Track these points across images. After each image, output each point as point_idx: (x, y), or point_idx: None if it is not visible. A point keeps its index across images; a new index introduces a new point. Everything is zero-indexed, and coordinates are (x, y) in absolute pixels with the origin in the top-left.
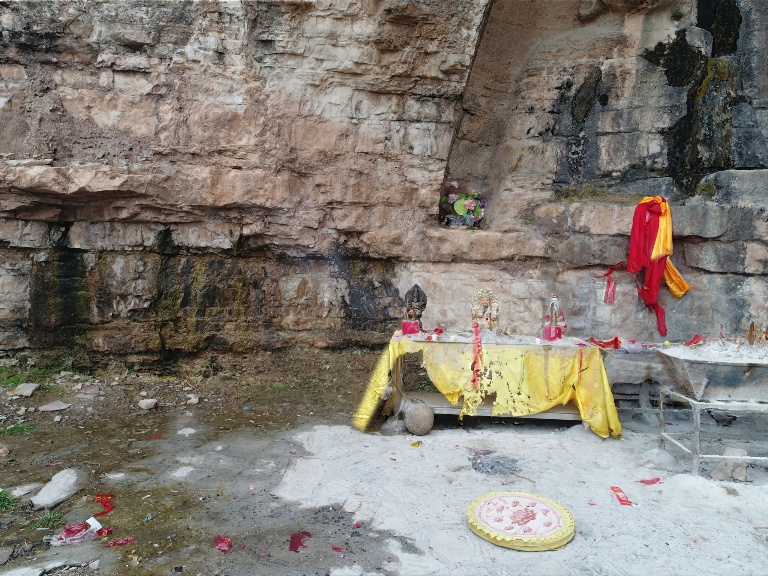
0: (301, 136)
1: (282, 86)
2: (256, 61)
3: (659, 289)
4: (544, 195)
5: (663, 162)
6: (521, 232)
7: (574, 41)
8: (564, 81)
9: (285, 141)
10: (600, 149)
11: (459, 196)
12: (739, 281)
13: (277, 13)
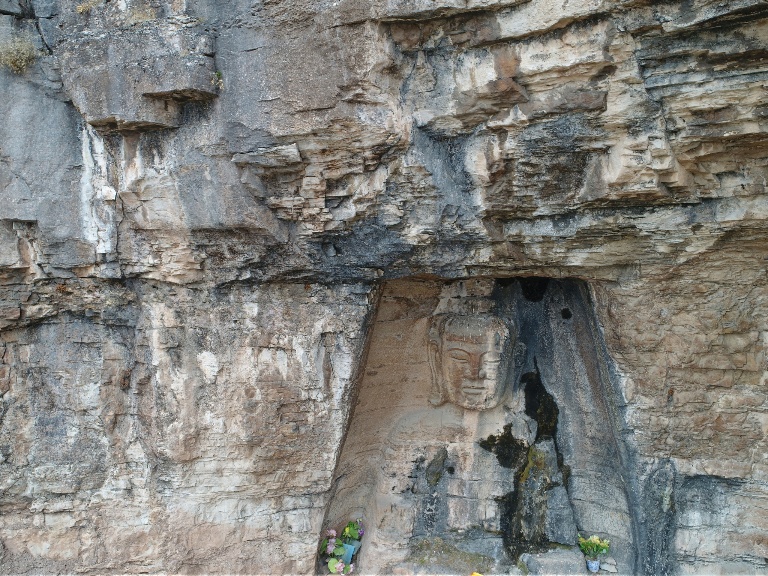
0: (197, 540)
1: (180, 507)
2: (158, 492)
3: None
4: (400, 557)
5: (497, 526)
6: None
7: (425, 426)
8: (418, 457)
9: (183, 546)
10: (449, 509)
11: (337, 541)
12: None
13: (172, 464)
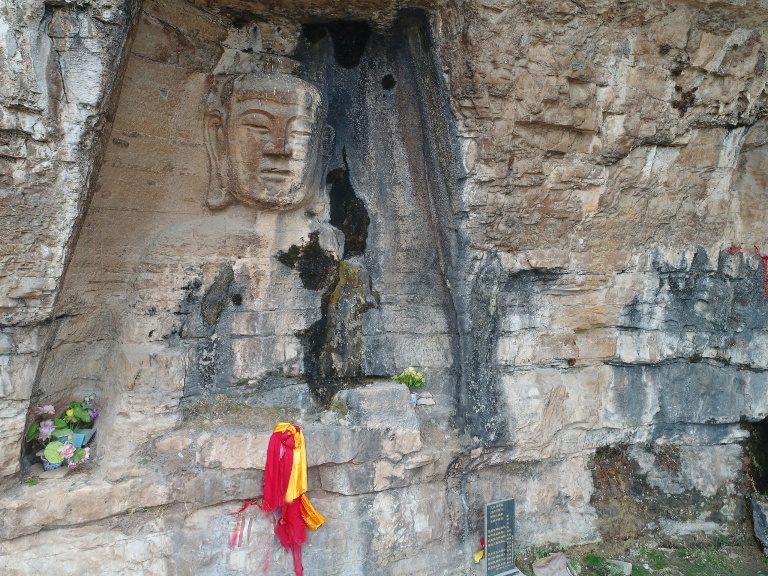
0: None
1: None
2: None
3: (296, 522)
4: (168, 424)
5: (300, 368)
6: (138, 478)
7: (202, 236)
8: (191, 281)
9: None
10: (235, 354)
11: (57, 422)
12: (370, 500)
13: None
